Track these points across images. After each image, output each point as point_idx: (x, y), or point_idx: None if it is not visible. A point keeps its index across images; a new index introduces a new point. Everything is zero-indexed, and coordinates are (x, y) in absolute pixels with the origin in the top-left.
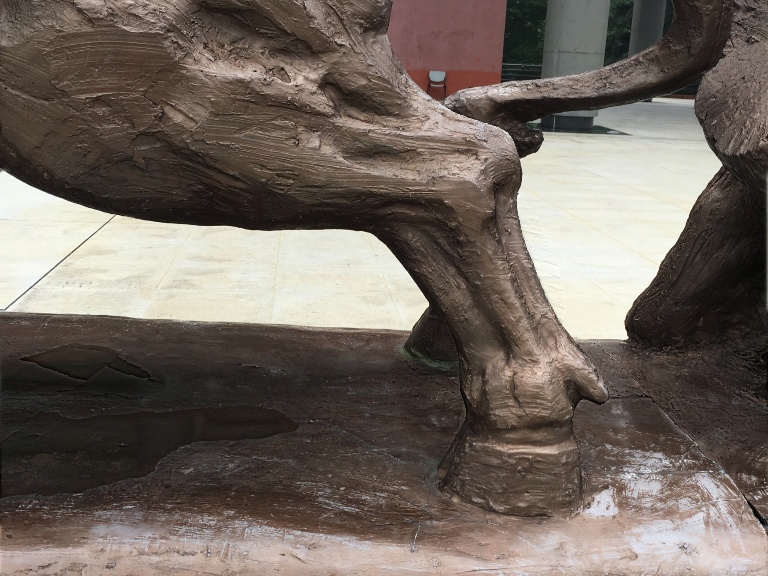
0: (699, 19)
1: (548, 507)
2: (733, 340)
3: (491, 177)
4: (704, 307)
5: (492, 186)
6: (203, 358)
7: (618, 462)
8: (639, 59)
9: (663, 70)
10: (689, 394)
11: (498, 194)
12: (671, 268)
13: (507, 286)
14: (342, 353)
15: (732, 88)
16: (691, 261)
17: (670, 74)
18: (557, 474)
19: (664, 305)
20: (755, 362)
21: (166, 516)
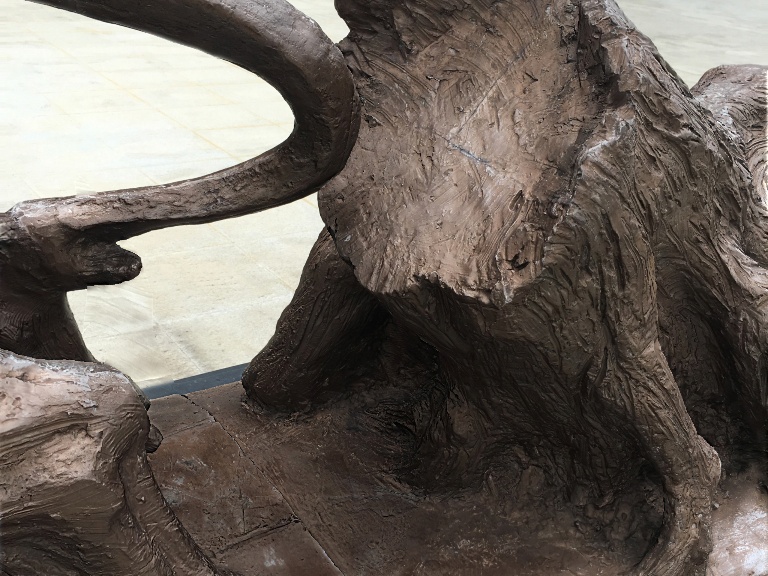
0: (326, 132)
1: None
2: (359, 393)
3: (112, 454)
4: (329, 368)
5: (115, 466)
6: None
7: None
8: (255, 169)
9: (286, 184)
10: (333, 492)
11: (122, 461)
12: (291, 332)
13: None
14: None
15: (361, 190)
16: (312, 325)
17: (295, 189)
18: None
19: (288, 372)
20: (387, 424)
21: None
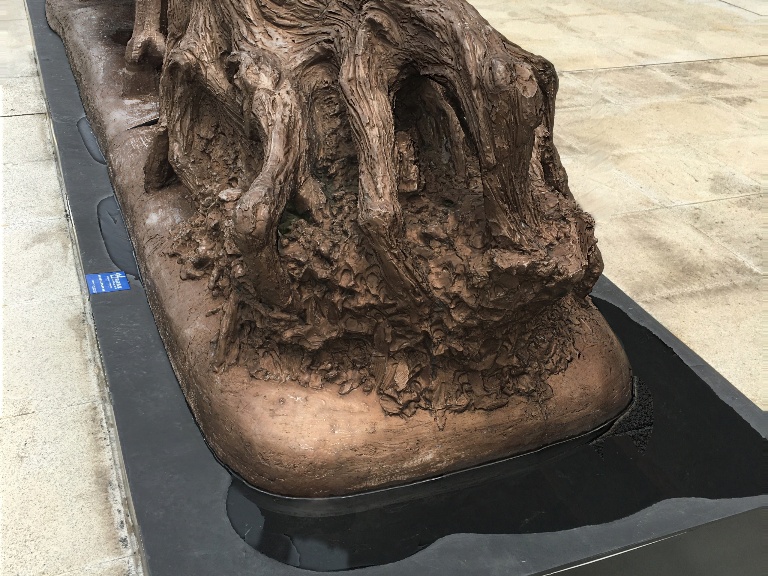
0: None
1: None
2: None
3: None
4: None
5: None
6: None
7: None
8: None
9: None
10: None
11: None
12: None
13: (136, 4)
14: None
15: None
16: None
17: None
18: None
19: None
20: None
21: (104, 53)
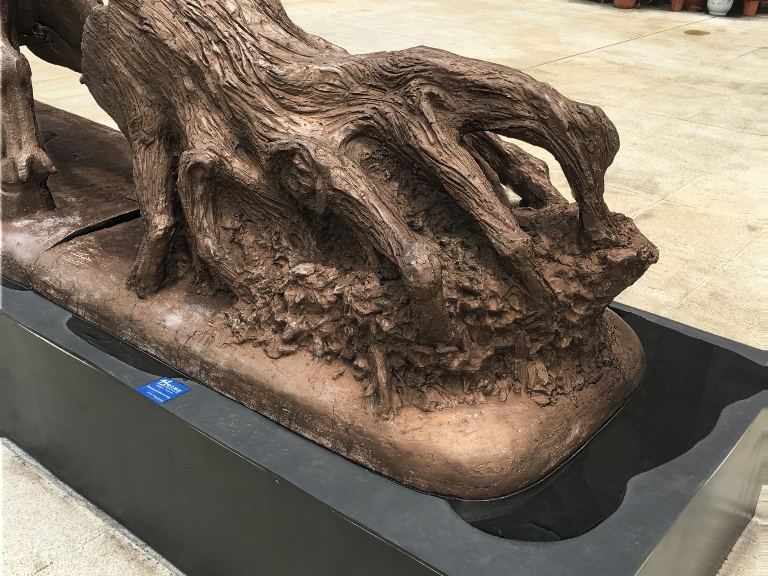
0: None
1: (4, 217)
2: None
3: (1, 77)
4: None
5: (0, 81)
6: (70, 147)
7: (63, 216)
8: None
9: None
10: None
11: (10, 85)
12: None
13: (4, 124)
14: (125, 160)
15: None
16: None
17: None
18: (6, 204)
19: None
20: None
21: None
